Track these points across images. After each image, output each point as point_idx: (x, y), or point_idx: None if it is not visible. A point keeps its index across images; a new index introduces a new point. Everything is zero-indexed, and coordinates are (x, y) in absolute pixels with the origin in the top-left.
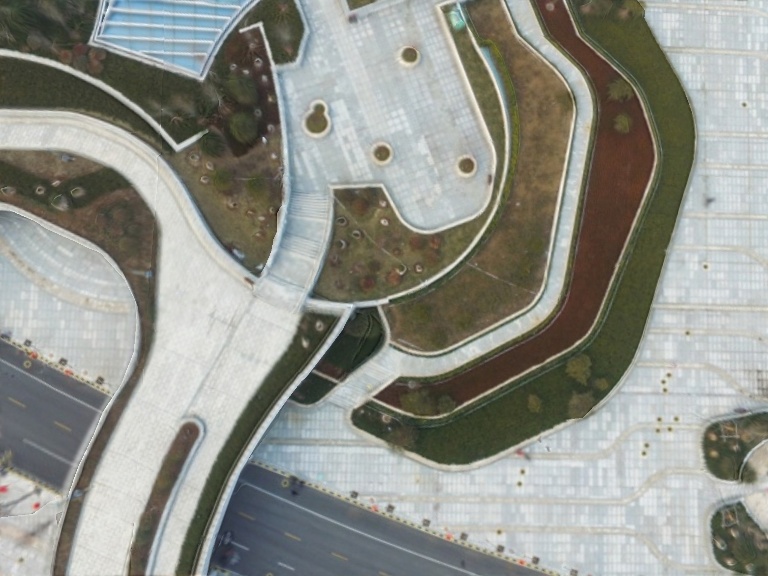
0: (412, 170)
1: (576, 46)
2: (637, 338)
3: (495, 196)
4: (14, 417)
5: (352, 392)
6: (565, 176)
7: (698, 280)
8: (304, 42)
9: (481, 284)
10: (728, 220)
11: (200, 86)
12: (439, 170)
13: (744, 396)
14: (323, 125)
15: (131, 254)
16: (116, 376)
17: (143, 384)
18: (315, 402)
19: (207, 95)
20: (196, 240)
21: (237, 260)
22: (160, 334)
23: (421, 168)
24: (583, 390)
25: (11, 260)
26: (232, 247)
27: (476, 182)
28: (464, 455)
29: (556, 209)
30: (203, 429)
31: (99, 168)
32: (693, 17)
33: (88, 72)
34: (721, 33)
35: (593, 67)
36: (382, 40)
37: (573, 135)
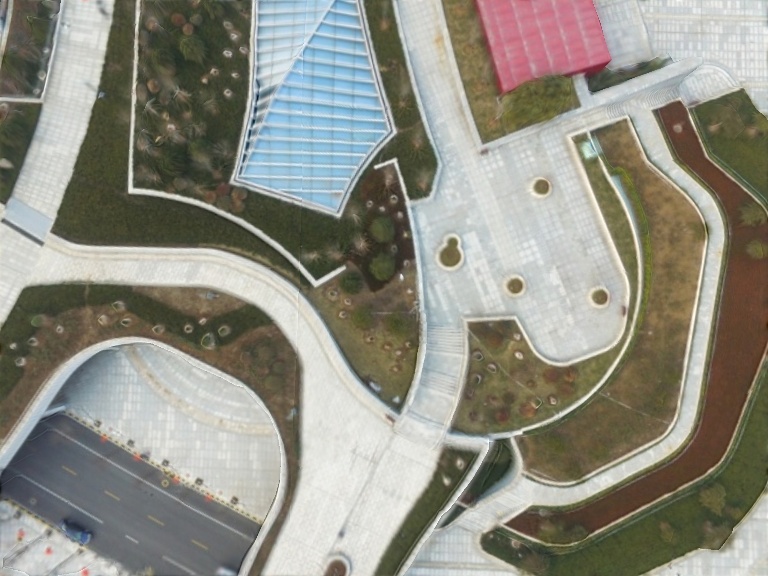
0: (544, 301)
1: (705, 168)
2: None
3: (629, 327)
4: (153, 535)
5: (481, 517)
6: (697, 303)
7: None
8: (437, 177)
9: (614, 414)
10: None
11: (337, 222)
12: (571, 301)
13: None
14: (457, 258)
15: (276, 391)
16: (249, 496)
17: (290, 521)
18: (444, 526)
19: (344, 232)
20: (337, 376)
21: (375, 394)
22: (305, 471)
23: (553, 299)
24: (718, 521)
25: (149, 382)
26: (369, 380)
27: (609, 313)
28: None
29: (689, 337)
30: (349, 567)
31: (242, 305)
32: None
33: (231, 211)
34: None
35: (723, 189)
36: (513, 171)
37: (705, 261)
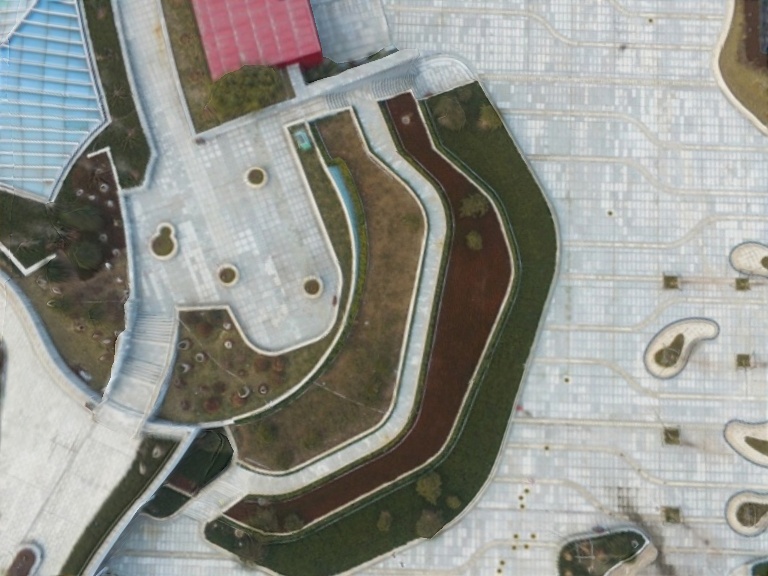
0: (259, 291)
1: (431, 160)
2: (493, 454)
3: (341, 317)
4: None
5: (205, 506)
6: (416, 294)
7: (559, 394)
8: (151, 166)
9: (328, 404)
10: (591, 332)
11: None
12: (286, 290)
13: (604, 514)
14: (169, 248)
15: None
16: None
17: None
18: (169, 515)
19: None
20: (40, 365)
21: (83, 383)
22: (2, 459)
23: (268, 288)
24: (432, 510)
25: None
26: (79, 369)
27: (322, 303)
28: (315, 571)
29: (406, 327)
30: (40, 555)
31: None
32: (558, 124)
33: None
34: (587, 140)
35: (448, 181)
36: (230, 161)
37: (425, 252)
